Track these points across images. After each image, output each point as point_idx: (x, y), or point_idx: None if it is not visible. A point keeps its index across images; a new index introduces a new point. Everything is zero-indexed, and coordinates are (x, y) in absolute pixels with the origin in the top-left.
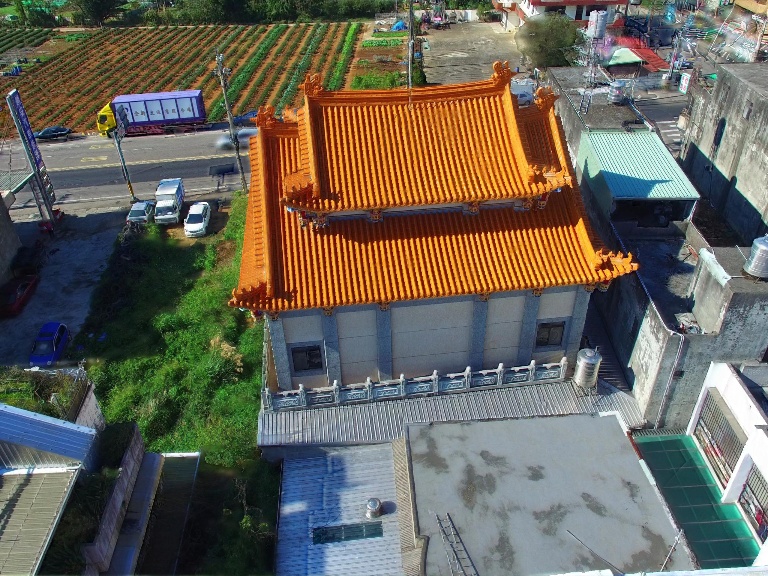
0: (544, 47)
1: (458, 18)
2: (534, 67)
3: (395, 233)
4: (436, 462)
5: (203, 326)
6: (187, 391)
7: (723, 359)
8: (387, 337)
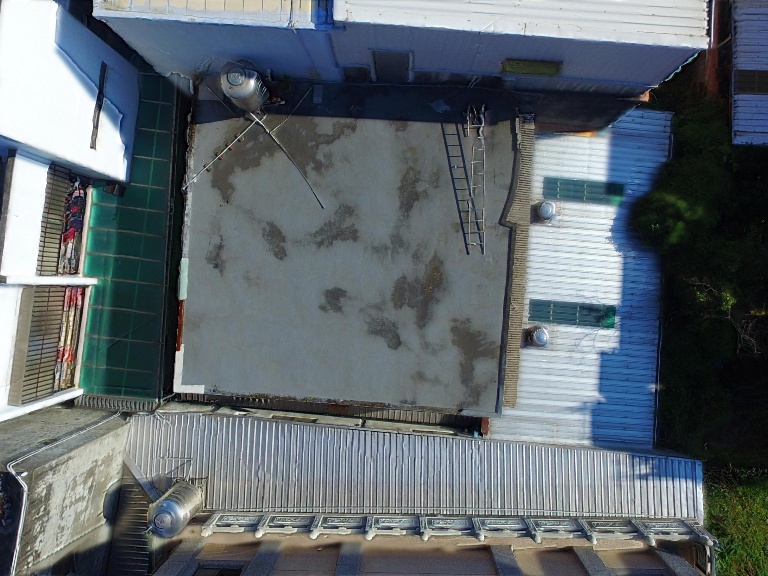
0: None
1: None
2: None
3: None
4: (467, 340)
5: None
6: None
7: None
8: None
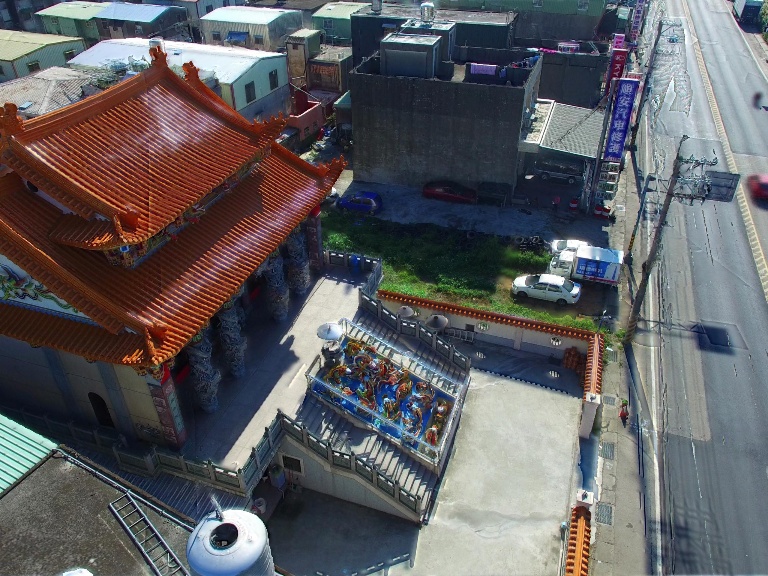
0: None
1: None
2: None
3: None
4: None
5: None
6: None
7: None
8: None
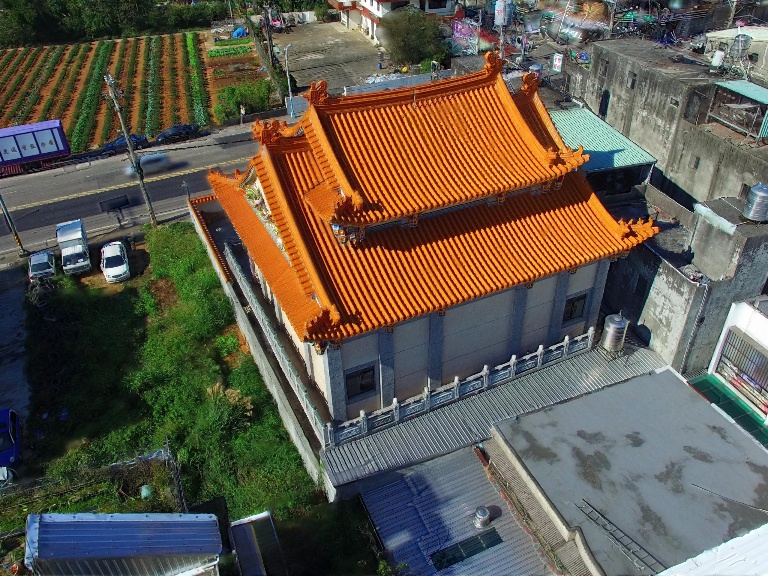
0: (407, 41)
1: (297, 20)
2: (394, 62)
3: (433, 235)
4: (543, 453)
5: (185, 376)
6: (197, 451)
7: (734, 299)
8: (439, 342)
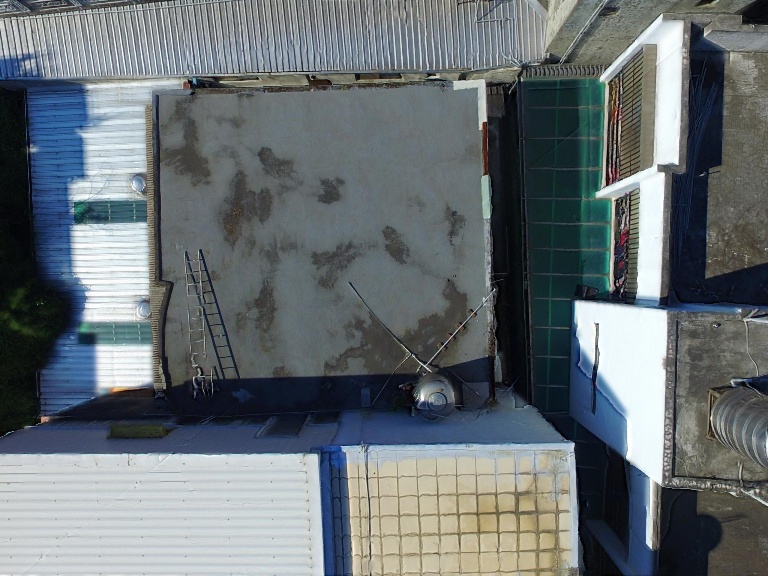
0: None
1: None
2: None
3: None
4: (194, 165)
5: None
6: None
7: None
8: None
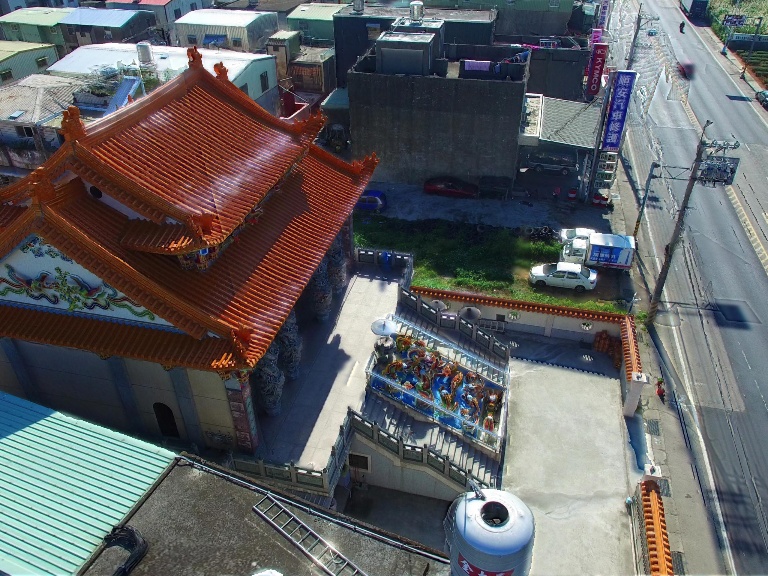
0: None
1: None
2: None
3: None
4: None
5: None
6: None
7: None
8: None
